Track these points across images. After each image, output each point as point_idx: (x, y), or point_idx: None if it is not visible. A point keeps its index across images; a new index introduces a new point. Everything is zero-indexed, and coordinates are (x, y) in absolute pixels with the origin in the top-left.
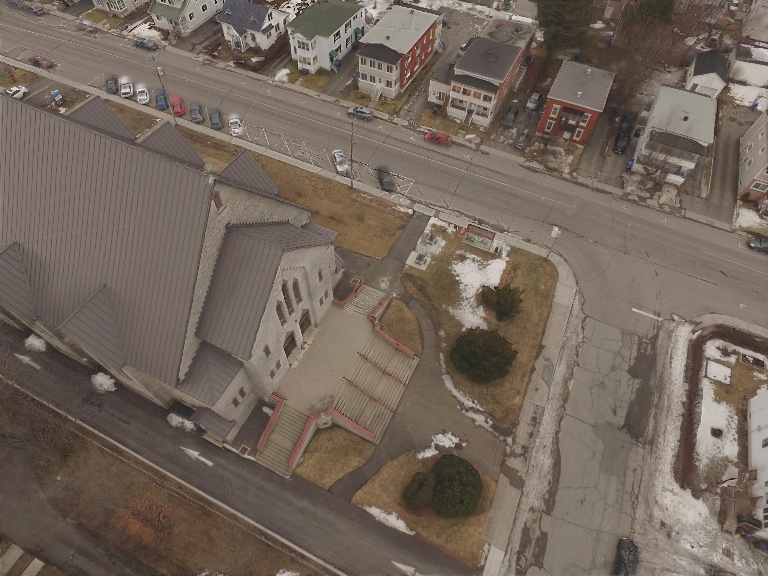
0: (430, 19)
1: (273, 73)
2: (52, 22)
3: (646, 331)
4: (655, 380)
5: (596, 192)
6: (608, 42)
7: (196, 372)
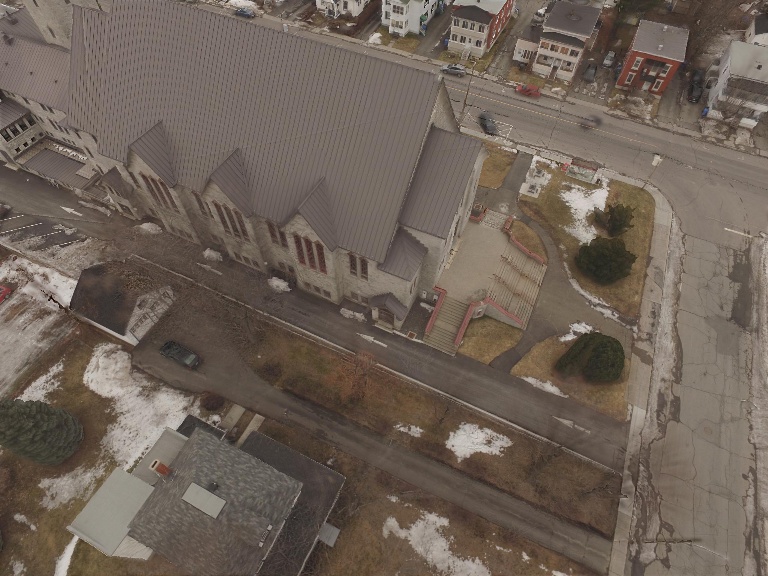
0: None
1: (366, 37)
2: None
3: (739, 246)
4: (753, 283)
5: (677, 135)
6: (669, 8)
7: (394, 254)
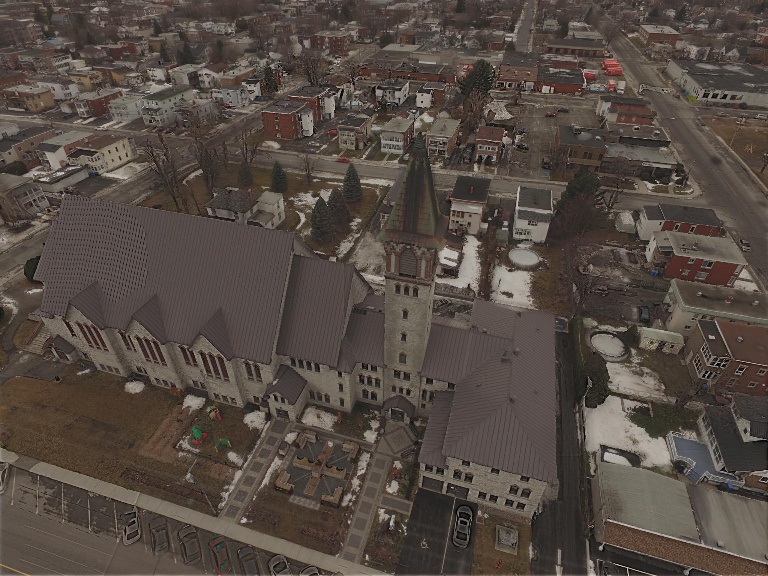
0: None
1: None
2: None
3: None
4: None
5: None
6: None
7: None
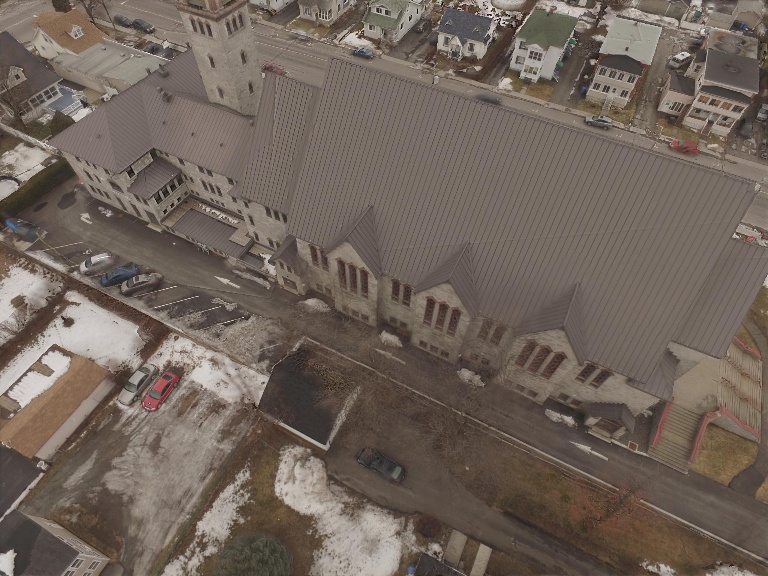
0: (656, 31)
1: (495, 82)
2: (263, 31)
3: None
4: None
5: None
6: None
7: None
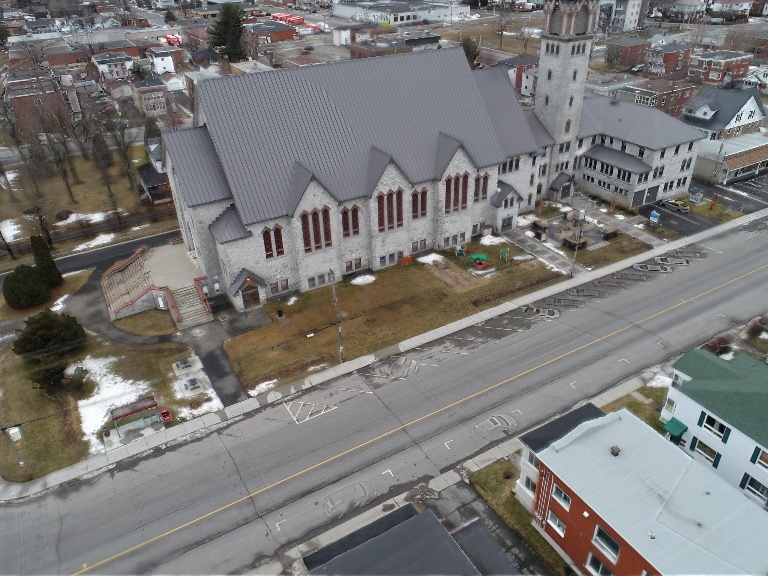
0: None
1: None
2: None
3: None
4: None
5: None
6: None
7: None
